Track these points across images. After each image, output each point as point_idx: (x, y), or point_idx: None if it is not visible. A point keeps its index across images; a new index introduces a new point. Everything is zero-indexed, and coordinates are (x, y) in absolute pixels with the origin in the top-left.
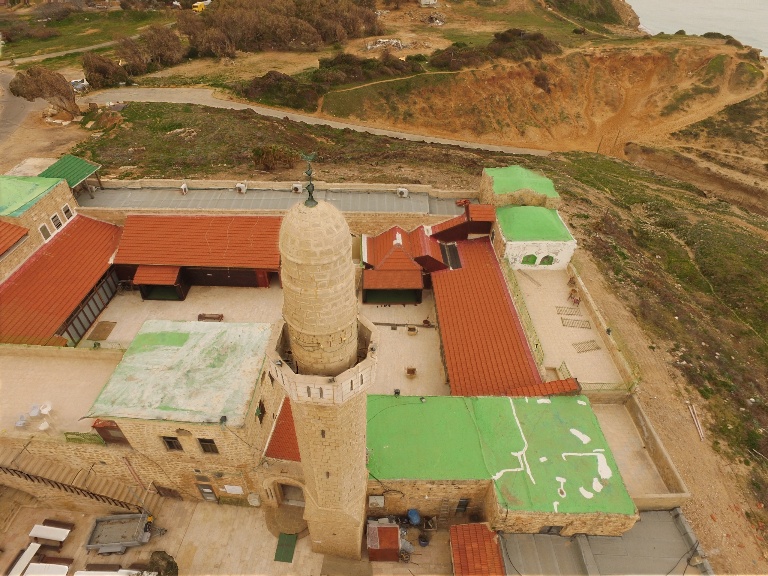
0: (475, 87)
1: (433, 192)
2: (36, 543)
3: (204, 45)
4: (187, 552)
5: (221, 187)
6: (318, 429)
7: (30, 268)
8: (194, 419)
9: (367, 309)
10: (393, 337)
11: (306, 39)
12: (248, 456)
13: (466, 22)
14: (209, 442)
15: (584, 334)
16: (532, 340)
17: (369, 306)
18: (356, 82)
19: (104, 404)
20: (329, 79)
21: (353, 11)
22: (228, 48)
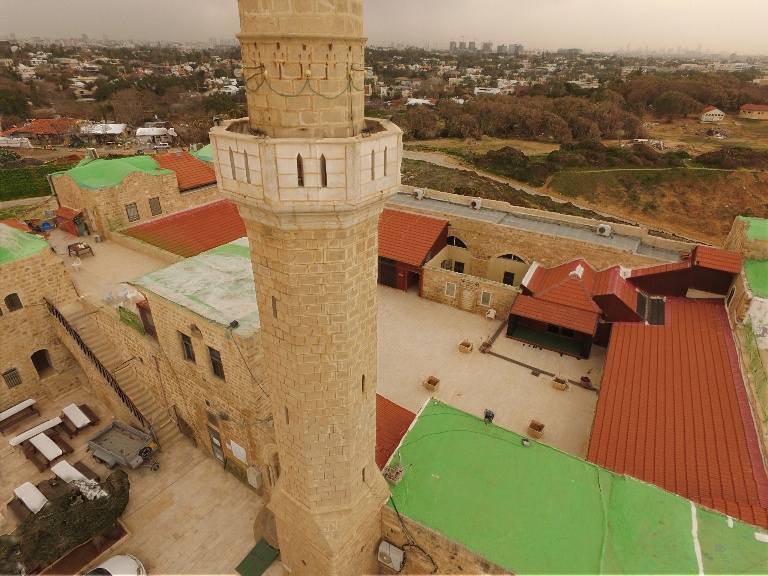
0: (754, 190)
1: (649, 238)
2: (60, 418)
3: (456, 126)
4: (162, 502)
5: (400, 191)
6: (268, 293)
7: (211, 209)
8: (208, 315)
9: (509, 343)
10: (529, 382)
11: (554, 131)
12: (251, 396)
13: (758, 139)
14: (218, 357)
15: None
16: None
17: (513, 341)
18: (595, 166)
19: (150, 278)
20: (565, 160)
21: (614, 113)
22: (476, 131)
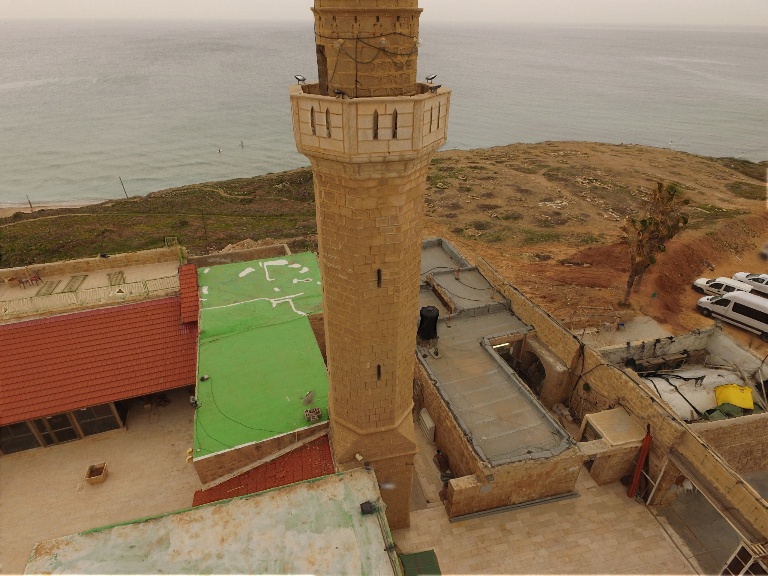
0: None
1: None
2: None
3: None
4: None
5: None
6: None
7: None
8: None
9: None
10: None
11: None
12: None
13: None
14: None
15: (95, 279)
16: (106, 299)
17: None
18: None
19: None
20: None
21: None
22: None
